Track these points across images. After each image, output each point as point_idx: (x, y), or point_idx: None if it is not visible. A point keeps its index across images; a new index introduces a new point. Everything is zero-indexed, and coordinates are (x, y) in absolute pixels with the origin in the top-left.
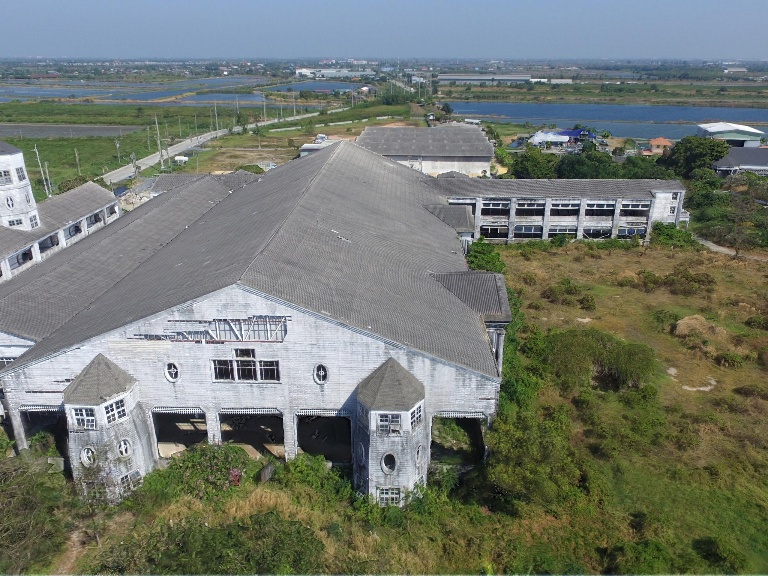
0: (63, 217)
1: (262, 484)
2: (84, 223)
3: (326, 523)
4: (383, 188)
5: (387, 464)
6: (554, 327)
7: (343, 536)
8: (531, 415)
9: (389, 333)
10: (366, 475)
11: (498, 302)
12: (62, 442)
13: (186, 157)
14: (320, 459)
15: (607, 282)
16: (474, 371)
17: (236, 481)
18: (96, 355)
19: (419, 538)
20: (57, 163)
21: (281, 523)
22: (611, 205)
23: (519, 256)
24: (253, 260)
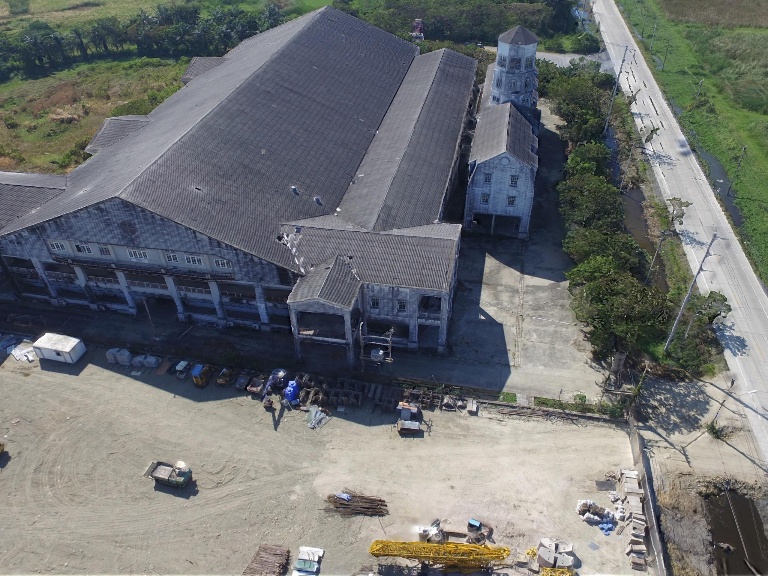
0: None
1: None
2: None
3: None
4: None
5: None
6: None
7: None
8: None
9: None
10: None
11: None
12: None
13: None
14: None
15: (28, 164)
16: None
17: None
18: None
19: None
20: None
21: None
22: None
23: None
24: None
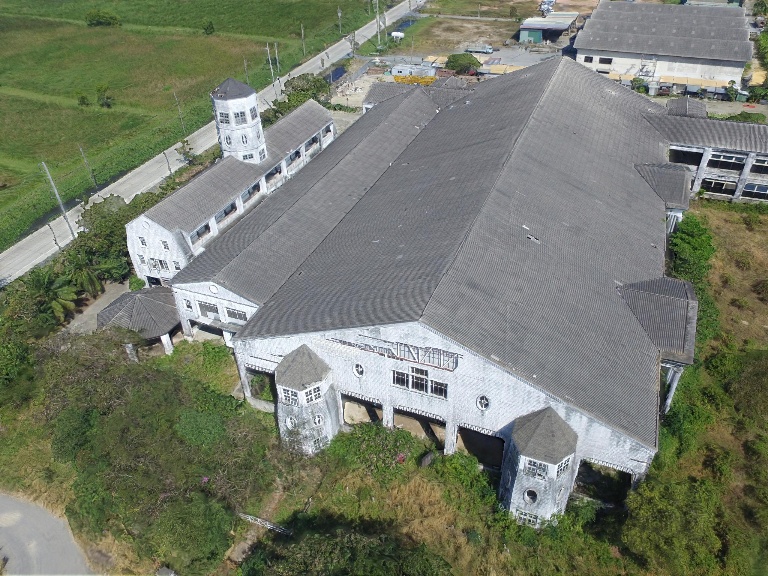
0: (286, 145)
1: (422, 468)
2: (303, 149)
3: (469, 525)
4: (594, 140)
5: (529, 495)
6: (753, 338)
7: (481, 542)
8: (680, 490)
9: (552, 384)
10: (509, 497)
11: (683, 337)
12: (274, 384)
13: (402, 33)
14: (473, 462)
15: None
16: (630, 438)
17: (401, 461)
18: (302, 344)
19: (546, 564)
20: (286, 32)
21: (424, 565)
22: None
23: (741, 223)
24: (438, 285)
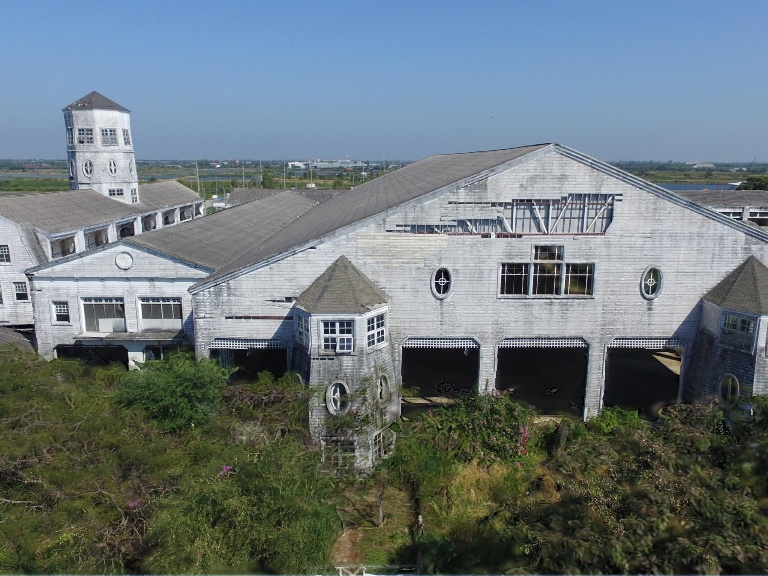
0: (158, 201)
1: (560, 451)
2: (177, 213)
3: None
4: None
5: None
6: None
7: None
8: None
9: None
10: None
11: None
12: None
13: None
14: (636, 415)
15: None
16: None
17: None
18: (336, 258)
19: None
20: None
21: None
22: (737, 213)
23: None
24: None
